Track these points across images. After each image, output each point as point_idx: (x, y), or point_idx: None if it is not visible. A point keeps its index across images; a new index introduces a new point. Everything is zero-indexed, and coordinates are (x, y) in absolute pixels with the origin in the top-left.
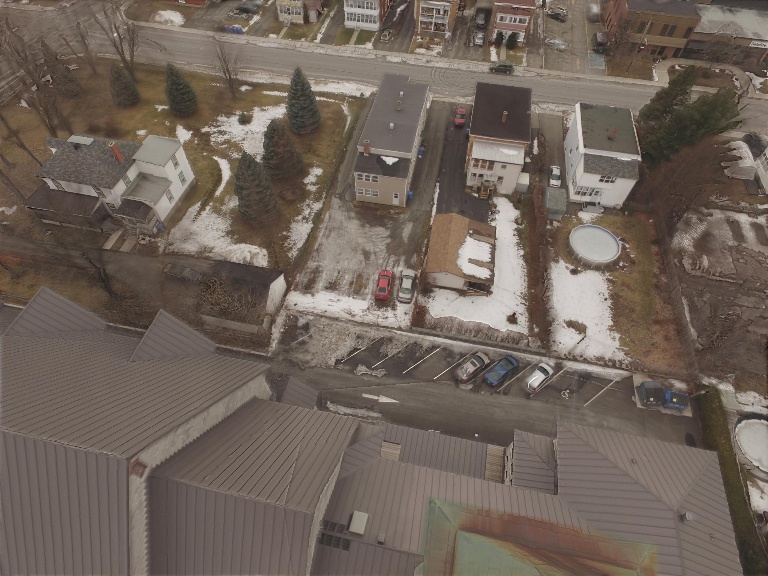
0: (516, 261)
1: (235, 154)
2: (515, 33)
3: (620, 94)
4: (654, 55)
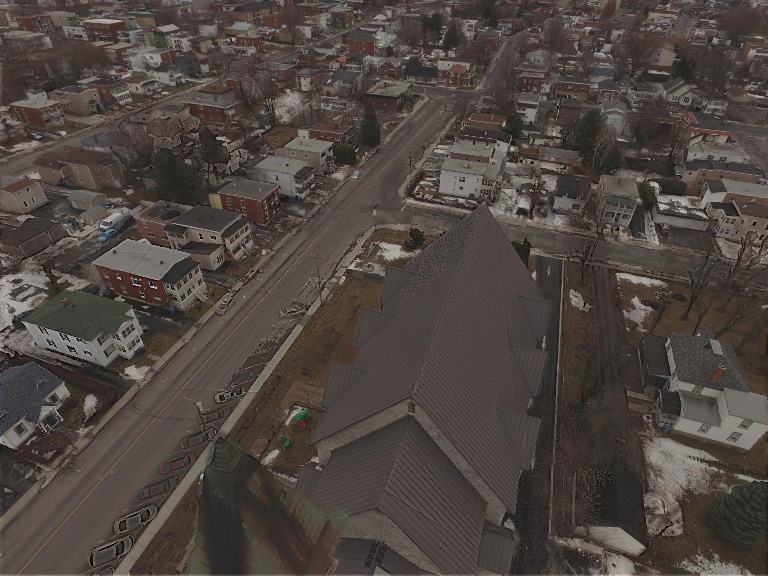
0: None
1: None
2: None
3: None
4: None
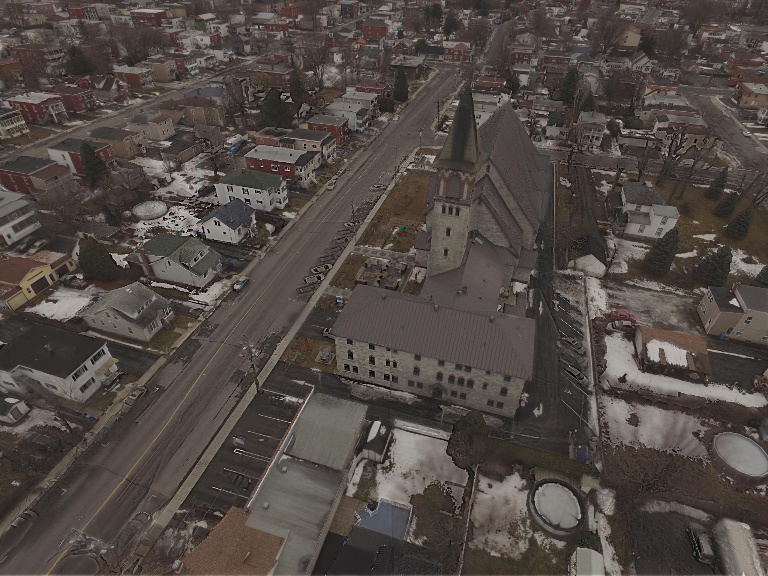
0: None
1: None
2: None
3: None
4: None
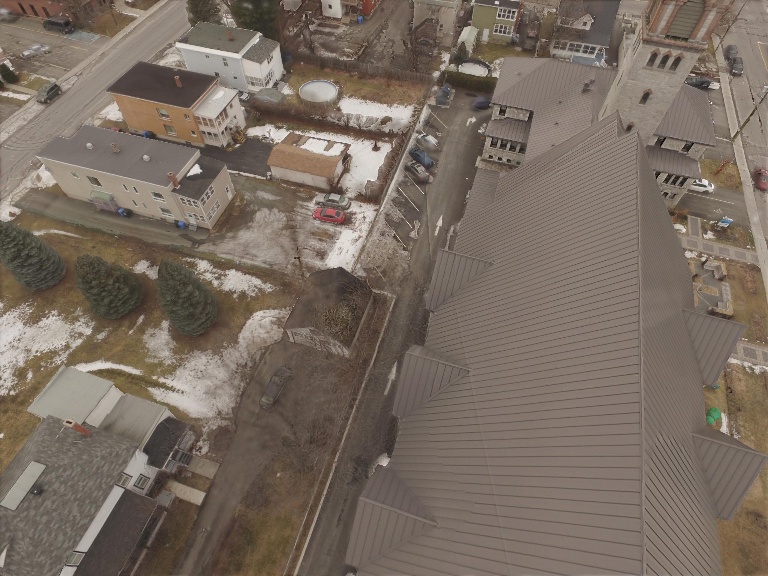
0: (321, 136)
1: (58, 359)
2: (2, 66)
3: (144, 38)
4: (103, 5)
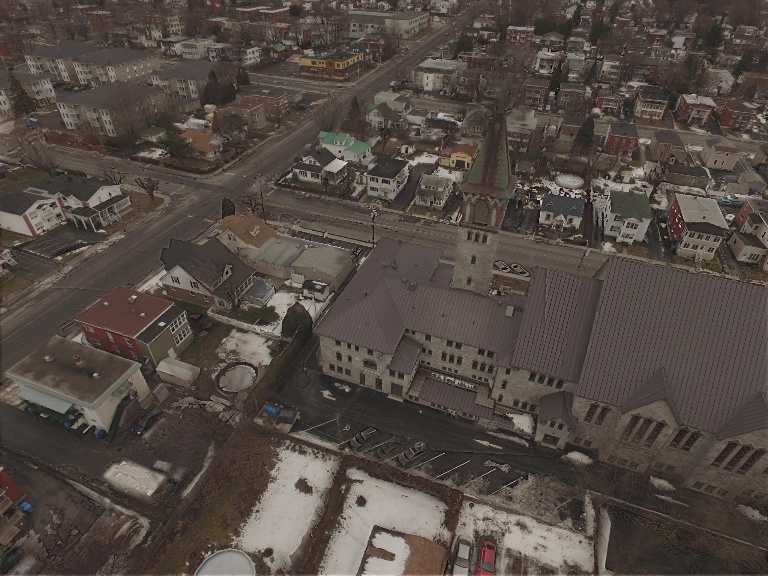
0: None
1: None
2: None
3: None
4: None
